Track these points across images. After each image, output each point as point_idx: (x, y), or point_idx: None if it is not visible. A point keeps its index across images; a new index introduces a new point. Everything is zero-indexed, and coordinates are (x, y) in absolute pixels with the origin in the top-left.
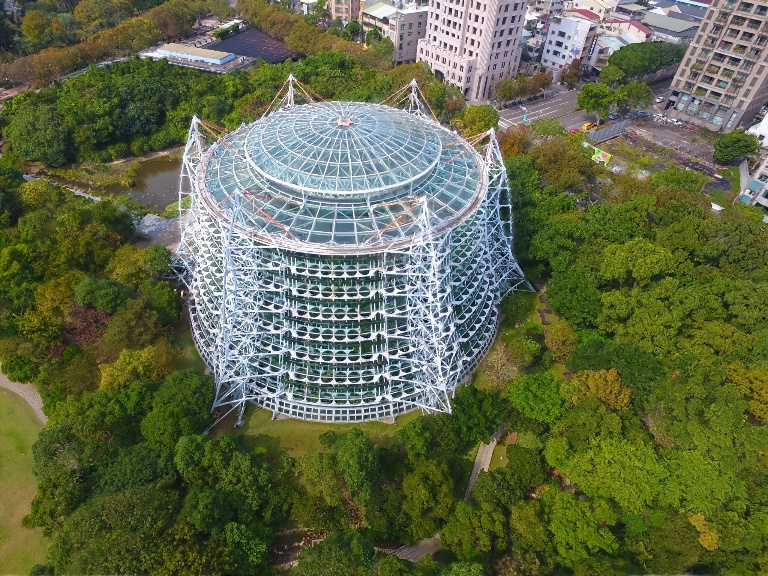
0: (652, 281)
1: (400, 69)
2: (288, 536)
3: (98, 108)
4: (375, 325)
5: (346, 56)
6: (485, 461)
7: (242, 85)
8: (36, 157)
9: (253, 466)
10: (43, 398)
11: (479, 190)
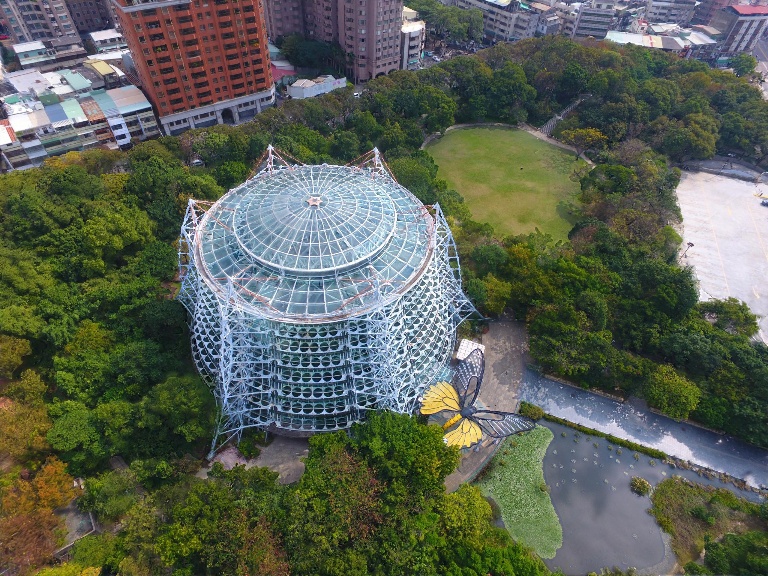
0: None
1: None
2: None
3: None
4: None
5: None
6: None
7: None
8: None
9: None
10: None
11: None
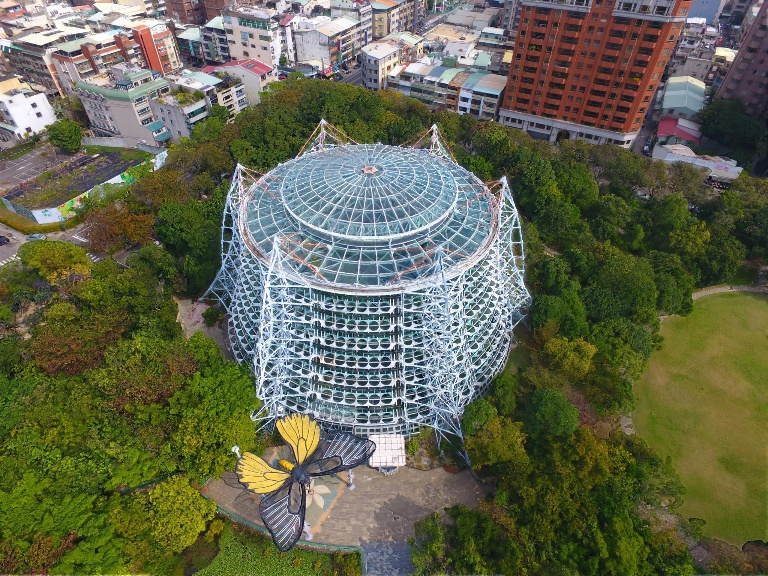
0: None
1: None
2: None
3: None
4: None
5: None
6: None
7: None
8: None
9: None
10: None
11: None
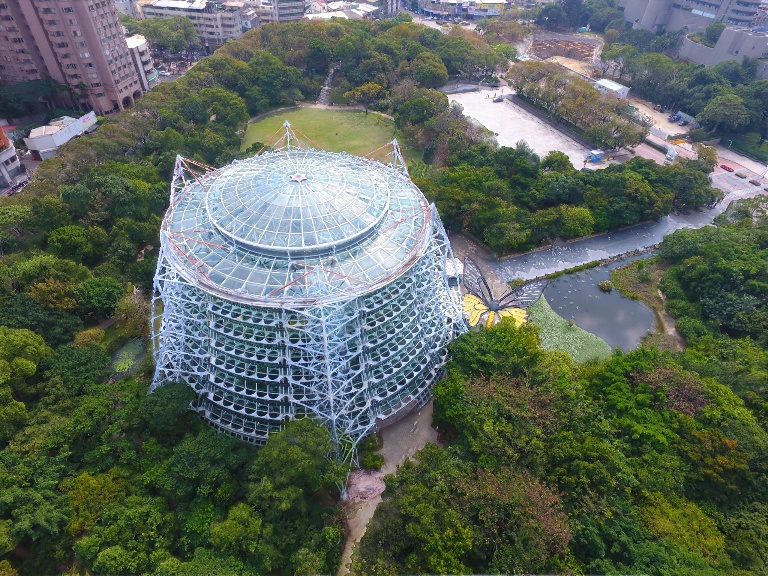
0: None
1: None
2: None
3: (731, 265)
4: None
5: None
6: None
7: None
8: None
9: None
10: None
11: None
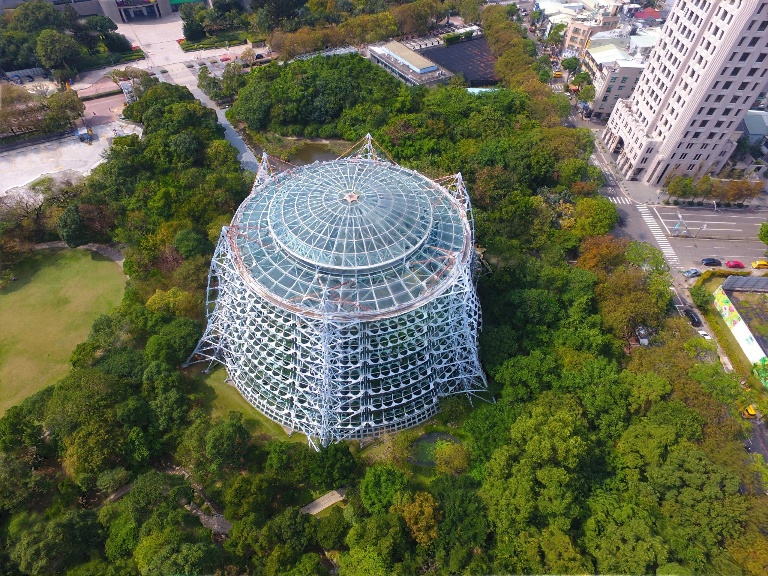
0: (552, 463)
1: (556, 131)
2: (175, 458)
3: (295, 94)
4: (294, 359)
5: (519, 100)
6: (322, 505)
7: (415, 101)
8: (242, 119)
9: (176, 403)
10: (125, 293)
11: (422, 299)
